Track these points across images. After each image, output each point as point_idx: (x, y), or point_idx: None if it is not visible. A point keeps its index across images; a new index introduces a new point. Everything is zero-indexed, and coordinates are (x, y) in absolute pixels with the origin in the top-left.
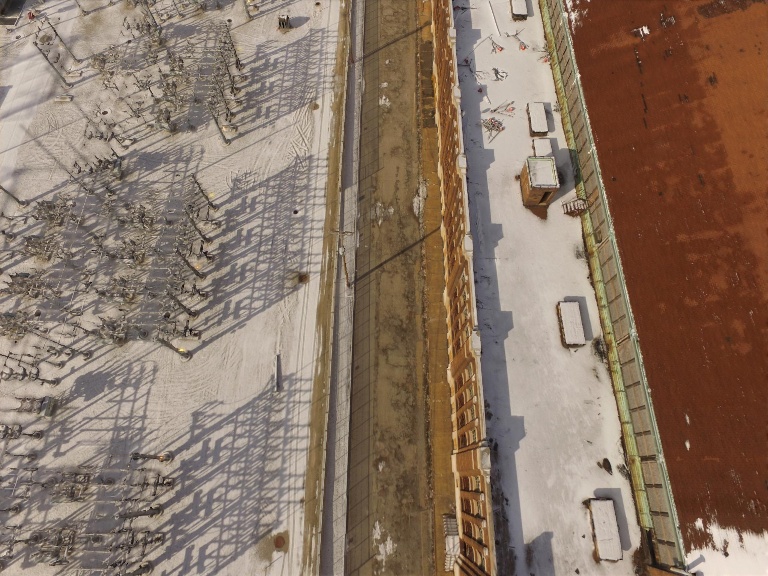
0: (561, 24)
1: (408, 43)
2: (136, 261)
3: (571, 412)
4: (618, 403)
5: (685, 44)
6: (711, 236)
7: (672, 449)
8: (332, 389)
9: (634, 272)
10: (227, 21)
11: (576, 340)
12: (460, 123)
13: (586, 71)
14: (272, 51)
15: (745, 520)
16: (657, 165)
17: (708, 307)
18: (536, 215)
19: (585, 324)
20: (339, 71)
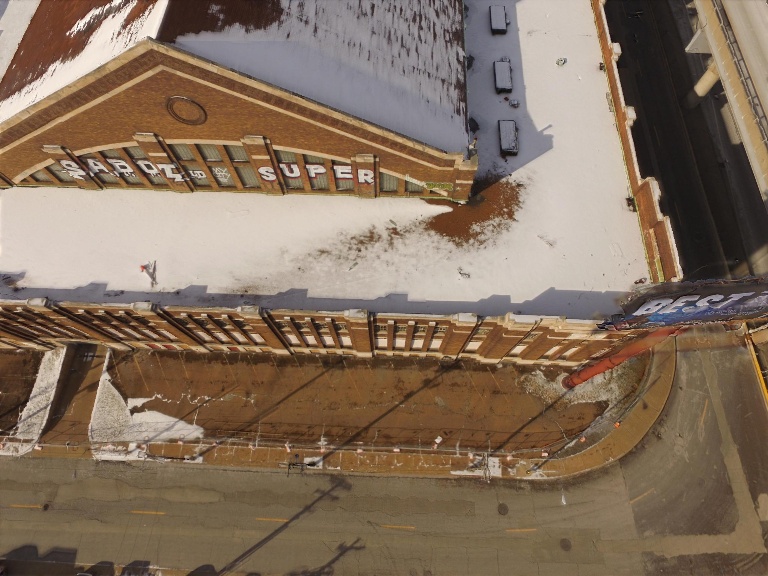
0: None
1: None
2: None
3: None
4: None
5: None
6: None
7: (7, 72)
8: None
9: None
10: None
11: None
12: None
13: None
14: None
15: (8, 94)
16: None
17: None
18: None
19: None
20: None
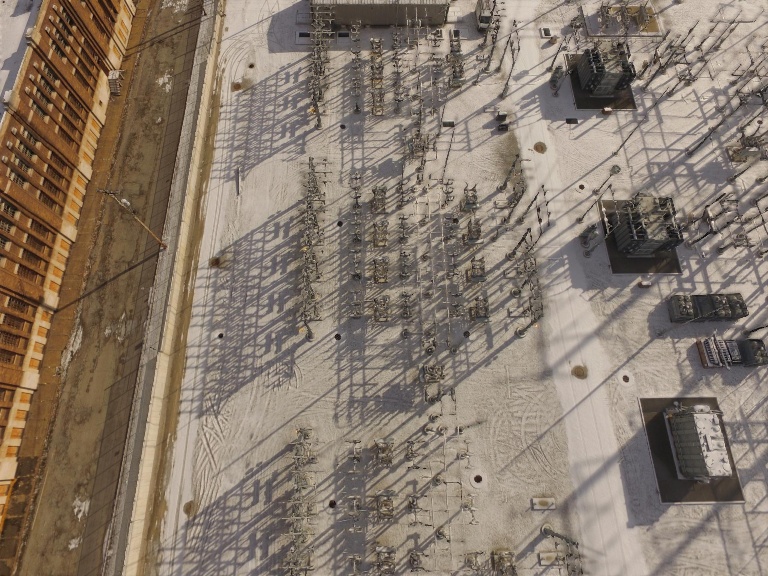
0: None
1: None
2: None
3: None
4: None
5: None
6: None
7: None
8: None
9: None
10: None
11: None
12: None
13: None
14: None
15: None
16: None
17: None
18: None
19: None
20: None
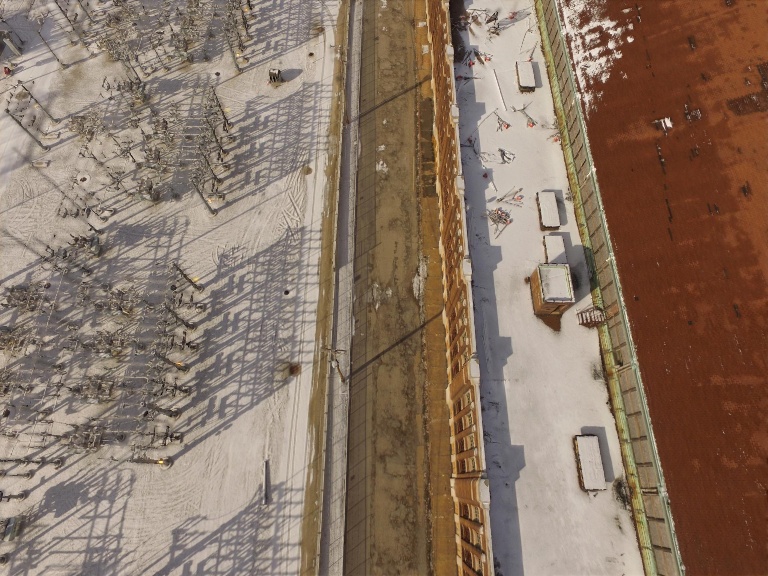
0: (573, 104)
1: (407, 100)
2: (114, 352)
3: (592, 572)
4: (644, 561)
5: (713, 144)
6: (750, 382)
7: None
8: (325, 504)
9: (662, 416)
10: (215, 74)
11: (596, 484)
12: (464, 219)
13: (602, 165)
14: (262, 108)
15: None
16: (685, 287)
17: (749, 471)
18: (548, 326)
19: (605, 462)
20: (333, 130)
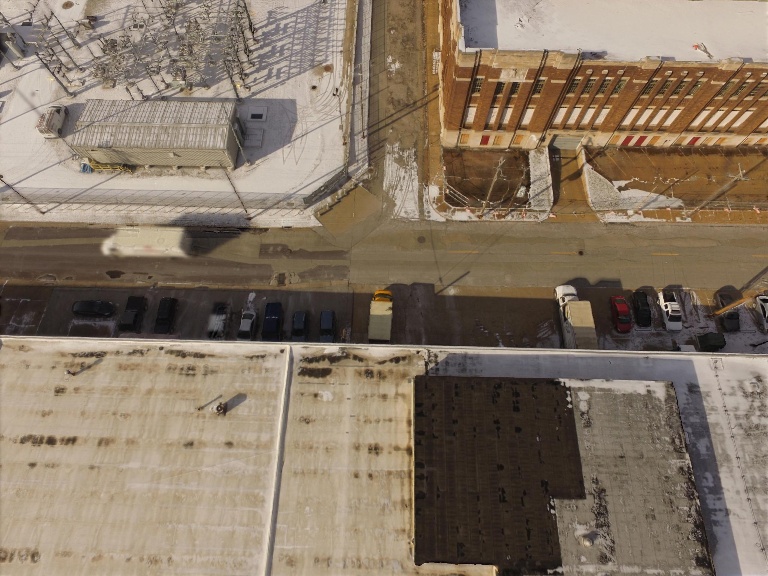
0: None
1: None
2: None
3: None
4: None
5: None
6: None
7: None
8: None
9: None
10: None
11: None
12: None
13: None
14: None
15: None
16: None
17: None
18: None
19: None
20: None
